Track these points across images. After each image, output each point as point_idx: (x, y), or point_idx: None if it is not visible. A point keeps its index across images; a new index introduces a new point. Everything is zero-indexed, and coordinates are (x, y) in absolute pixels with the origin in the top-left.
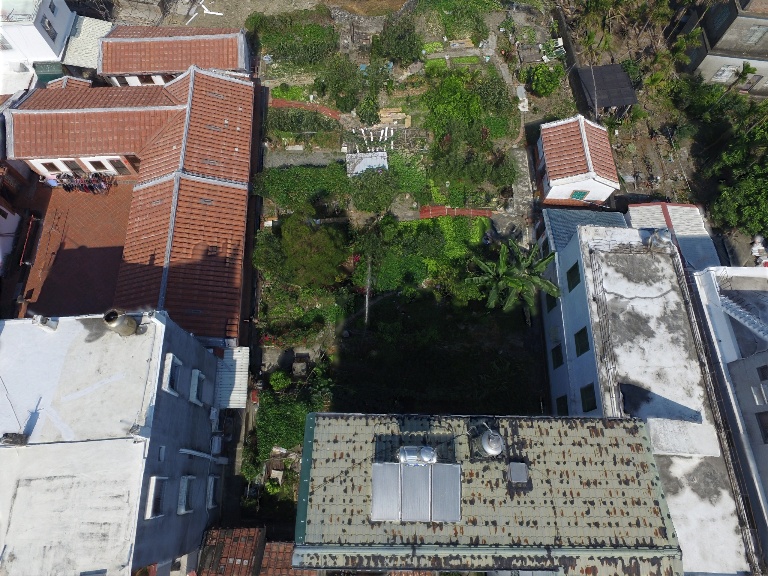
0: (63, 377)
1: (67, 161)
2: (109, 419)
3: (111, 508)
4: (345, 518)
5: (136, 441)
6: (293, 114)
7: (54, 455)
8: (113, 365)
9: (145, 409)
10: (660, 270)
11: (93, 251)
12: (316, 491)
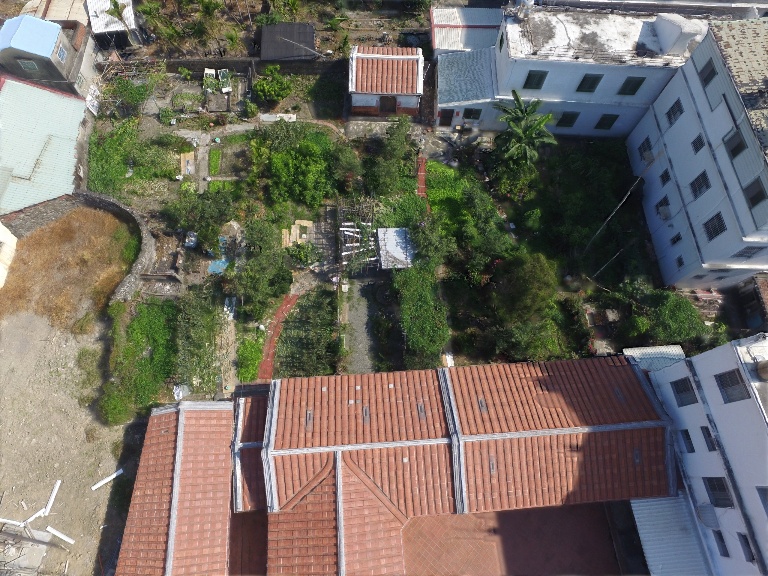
0: None
1: None
2: None
3: None
4: None
5: None
6: (314, 334)
7: None
8: None
9: None
10: (541, 19)
11: None
12: None
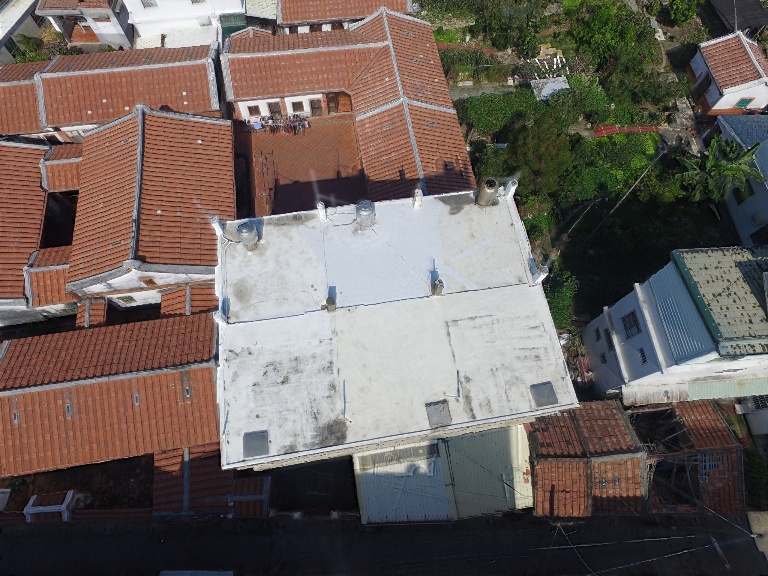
0: (445, 242)
1: (272, 103)
2: (499, 271)
3: (533, 336)
4: (745, 319)
5: (530, 286)
6: (467, 50)
7: (468, 301)
8: (483, 230)
9: (526, 261)
10: None
11: (307, 185)
12: (713, 302)
